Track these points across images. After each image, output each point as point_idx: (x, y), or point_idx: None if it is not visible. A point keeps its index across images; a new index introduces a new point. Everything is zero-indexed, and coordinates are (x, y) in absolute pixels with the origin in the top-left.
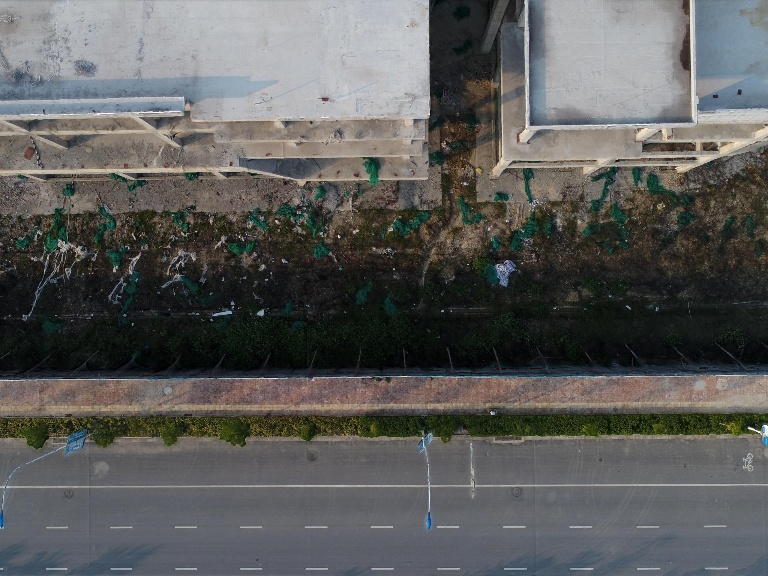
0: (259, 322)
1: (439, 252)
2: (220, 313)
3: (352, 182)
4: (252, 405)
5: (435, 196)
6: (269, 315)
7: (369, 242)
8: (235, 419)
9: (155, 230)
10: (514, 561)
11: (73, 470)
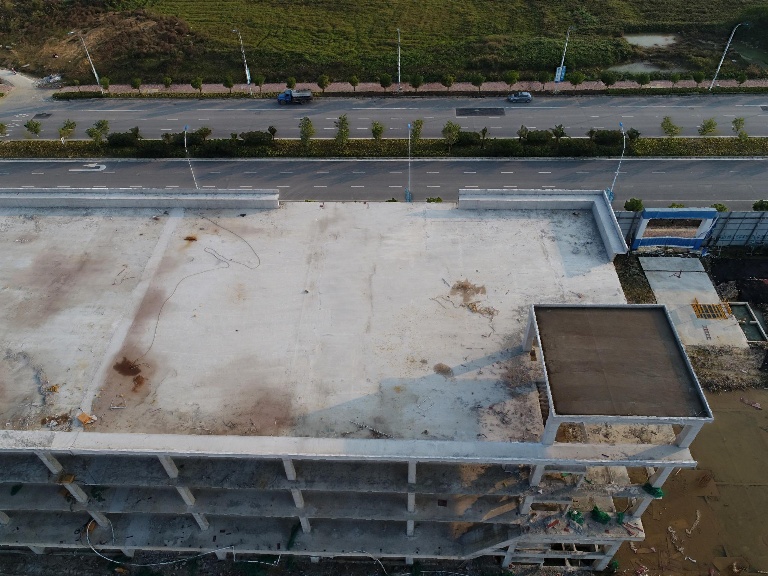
0: None
1: None
2: None
3: None
4: None
5: None
6: None
7: None
8: None
9: None
10: (1, 176)
11: None
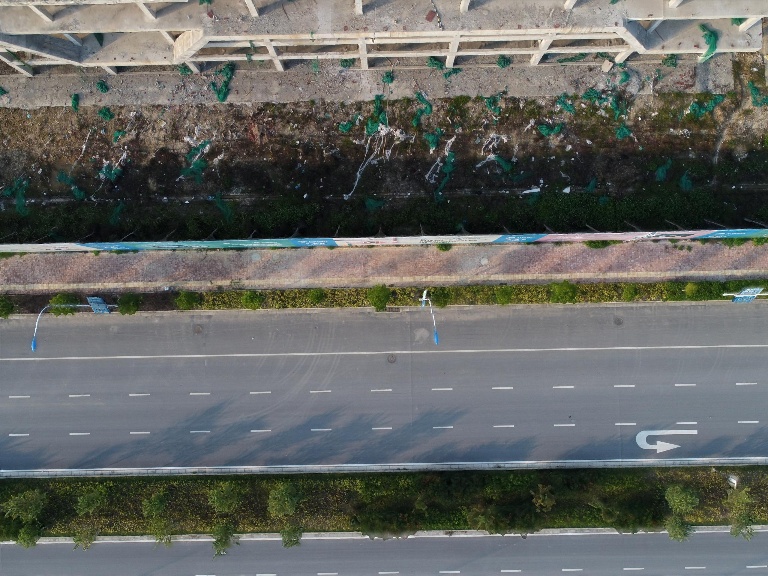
0: (570, 197)
1: (731, 132)
2: (529, 190)
3: (652, 68)
4: (563, 274)
5: (727, 81)
6: (576, 192)
7: (667, 124)
8: (549, 286)
9: (468, 114)
10: None
11: (395, 337)
